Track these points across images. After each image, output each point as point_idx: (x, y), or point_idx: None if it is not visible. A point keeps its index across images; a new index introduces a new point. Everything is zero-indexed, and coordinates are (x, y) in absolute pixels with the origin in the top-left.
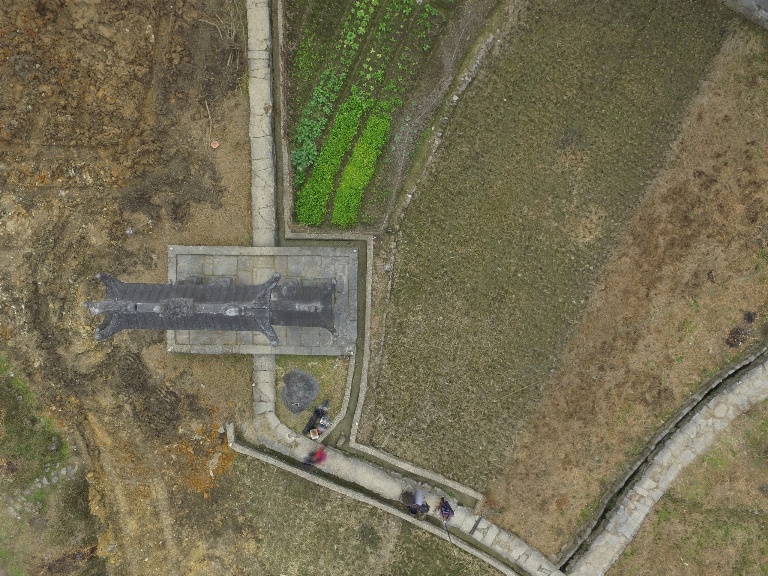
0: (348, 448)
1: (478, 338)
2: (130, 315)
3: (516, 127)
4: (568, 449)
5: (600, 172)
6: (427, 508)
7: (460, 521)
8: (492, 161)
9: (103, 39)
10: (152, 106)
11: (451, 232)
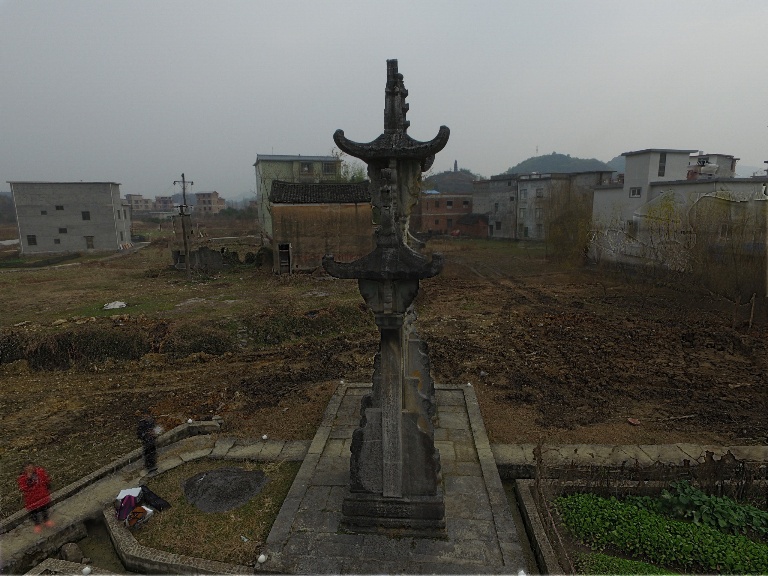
0: None
1: None
2: None
3: None
4: None
5: None
6: None
7: None
8: None
9: None
10: None
11: None
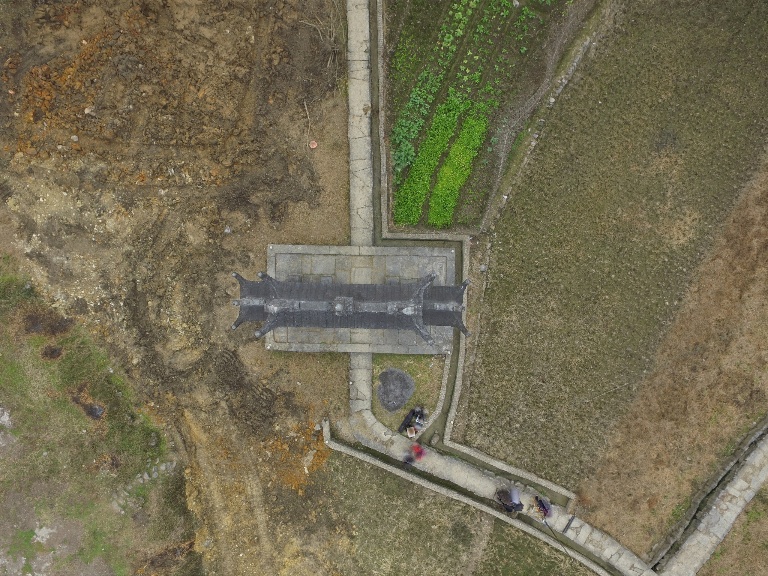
0: (441, 446)
1: (571, 338)
2: (288, 313)
3: (611, 129)
4: (660, 449)
5: (694, 175)
6: (521, 506)
7: (553, 520)
8: (587, 163)
9: (203, 40)
10: (250, 106)
11: (545, 233)
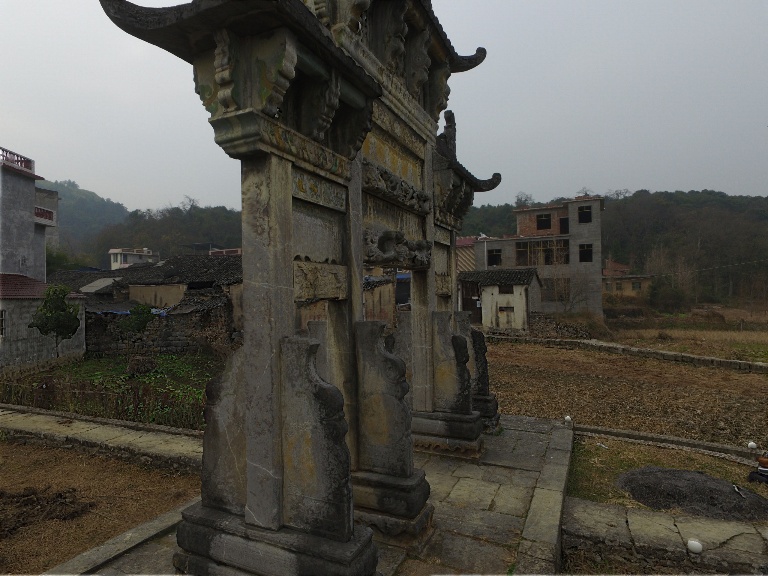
0: None
1: None
2: None
3: None
4: None
5: None
6: None
7: None
8: None
9: None
10: None
11: None
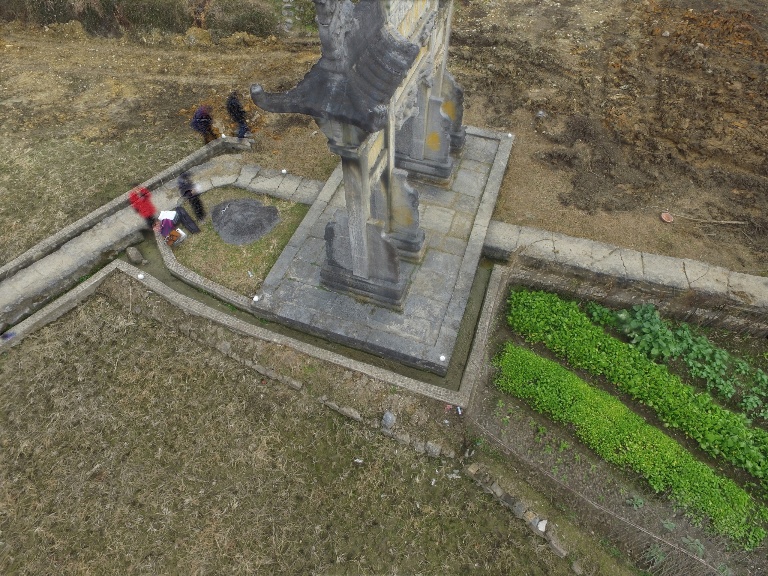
0: None
1: None
2: None
3: None
4: None
5: None
6: None
7: None
8: None
9: None
10: None
11: None
